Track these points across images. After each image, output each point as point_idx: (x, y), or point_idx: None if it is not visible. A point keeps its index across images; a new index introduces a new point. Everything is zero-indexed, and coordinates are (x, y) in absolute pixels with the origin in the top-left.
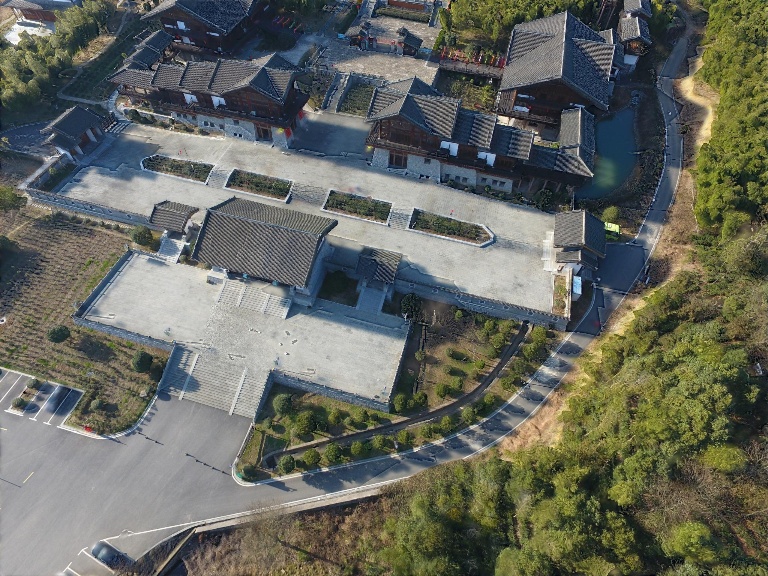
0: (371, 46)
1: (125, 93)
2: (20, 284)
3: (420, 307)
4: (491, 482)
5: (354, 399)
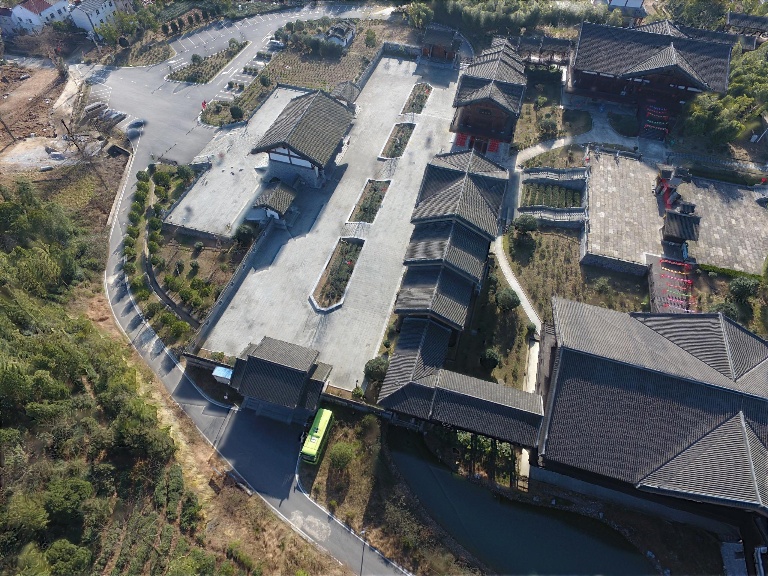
0: None
1: None
2: (311, 65)
3: (247, 247)
4: None
5: None
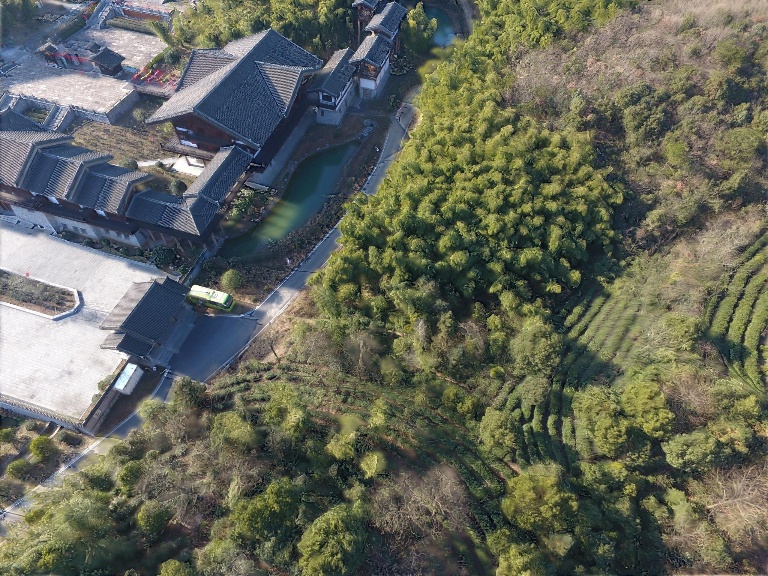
0: (73, 63)
1: None
2: None
3: None
4: None
5: None
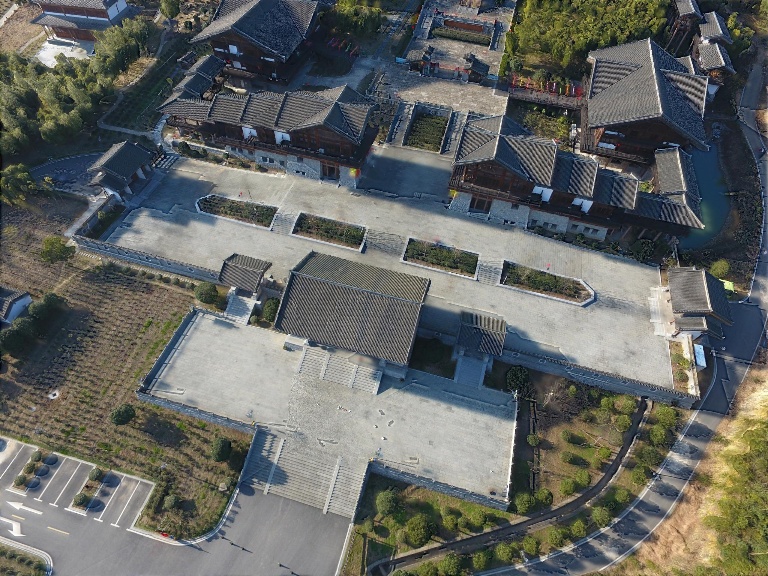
0: (432, 71)
1: (175, 124)
2: (72, 350)
3: None
4: None
5: (466, 495)
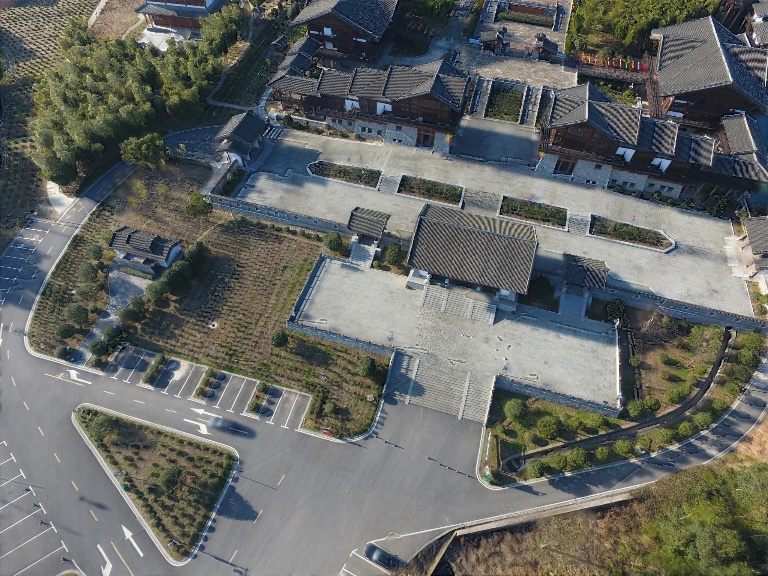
0: (503, 51)
1: (281, 99)
2: (223, 289)
3: None
4: (764, 488)
5: (582, 404)
